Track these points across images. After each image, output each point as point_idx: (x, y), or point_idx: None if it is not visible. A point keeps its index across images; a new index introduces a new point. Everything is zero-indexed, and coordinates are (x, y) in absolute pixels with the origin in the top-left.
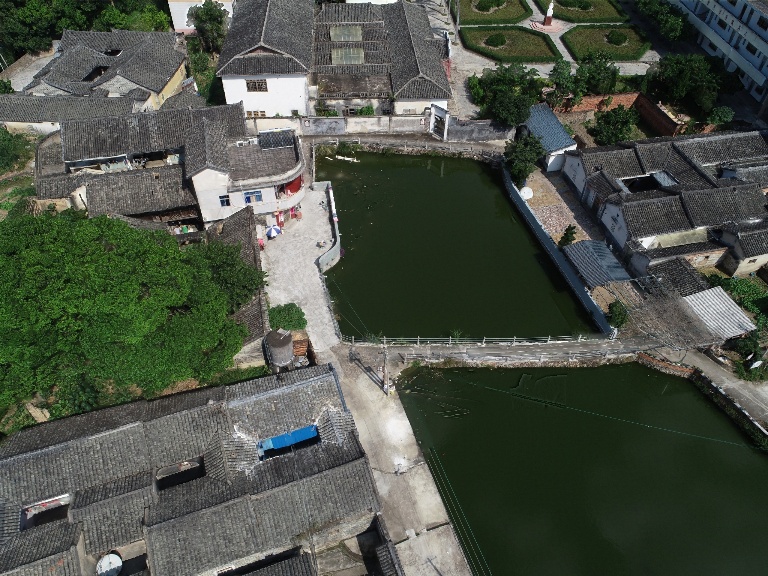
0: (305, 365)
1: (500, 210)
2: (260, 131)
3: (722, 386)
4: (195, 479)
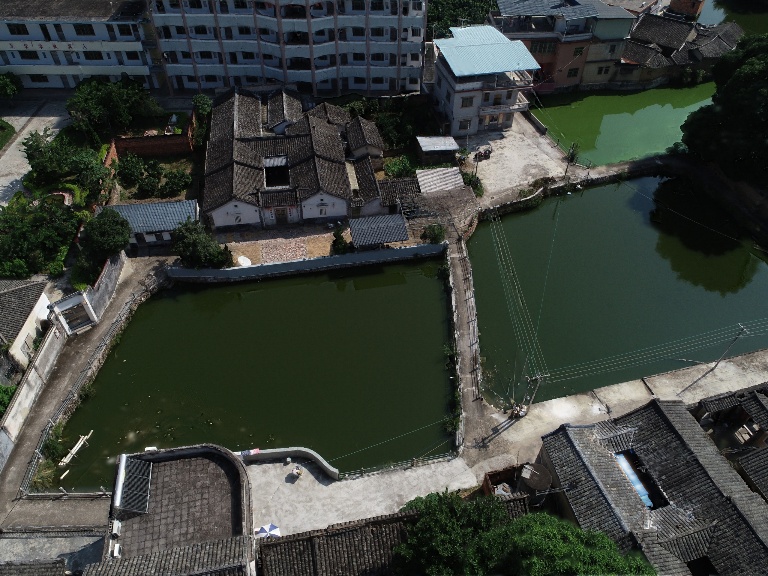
0: (508, 487)
1: (211, 309)
2: (117, 504)
3: (489, 206)
4: (714, 567)
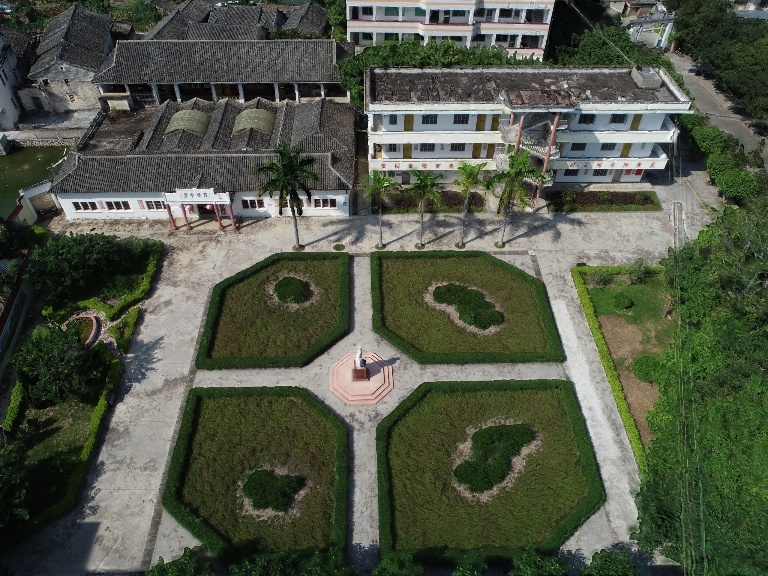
0: None
1: None
2: None
3: None
4: None
